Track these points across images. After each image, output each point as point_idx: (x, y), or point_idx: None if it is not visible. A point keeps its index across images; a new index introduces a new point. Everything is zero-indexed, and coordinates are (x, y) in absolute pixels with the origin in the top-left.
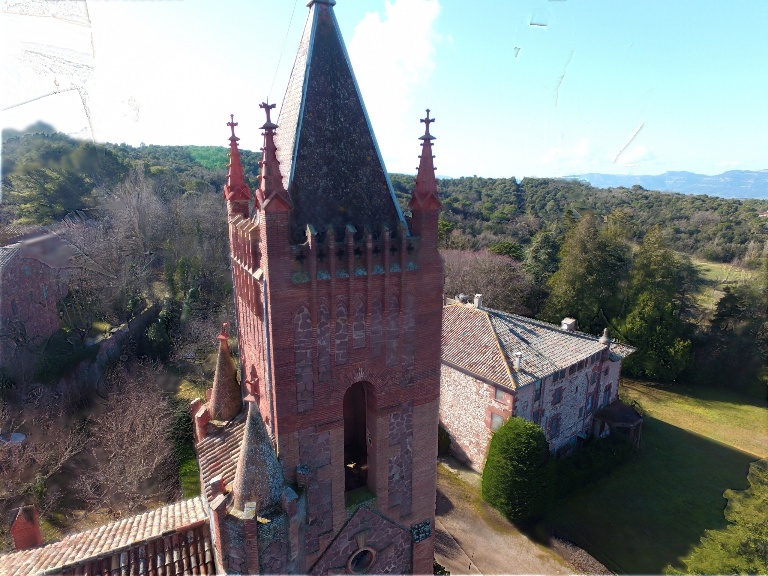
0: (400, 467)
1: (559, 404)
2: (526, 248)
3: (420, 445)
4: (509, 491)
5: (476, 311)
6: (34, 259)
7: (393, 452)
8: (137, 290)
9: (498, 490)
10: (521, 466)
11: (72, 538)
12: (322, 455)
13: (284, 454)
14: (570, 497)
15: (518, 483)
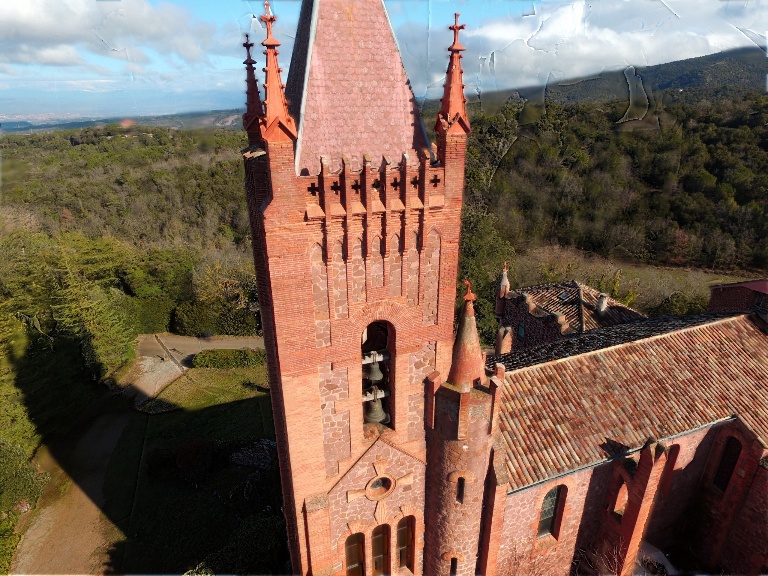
0: None
1: None
2: None
3: None
4: None
5: None
6: None
7: None
8: None
9: None
10: None
11: (589, 442)
12: None
13: None
14: None
15: None
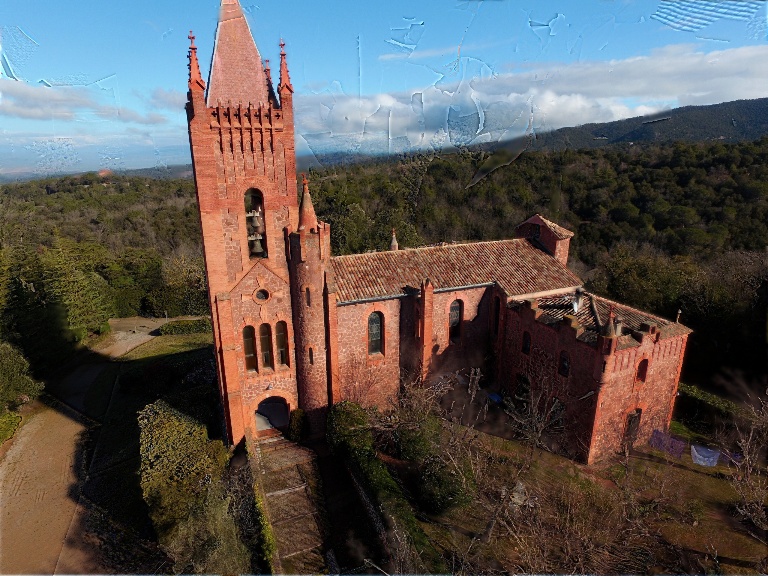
0: None
1: None
2: None
3: None
4: None
5: None
6: None
7: None
8: None
9: None
10: None
11: (395, 286)
12: None
13: None
14: None
15: None
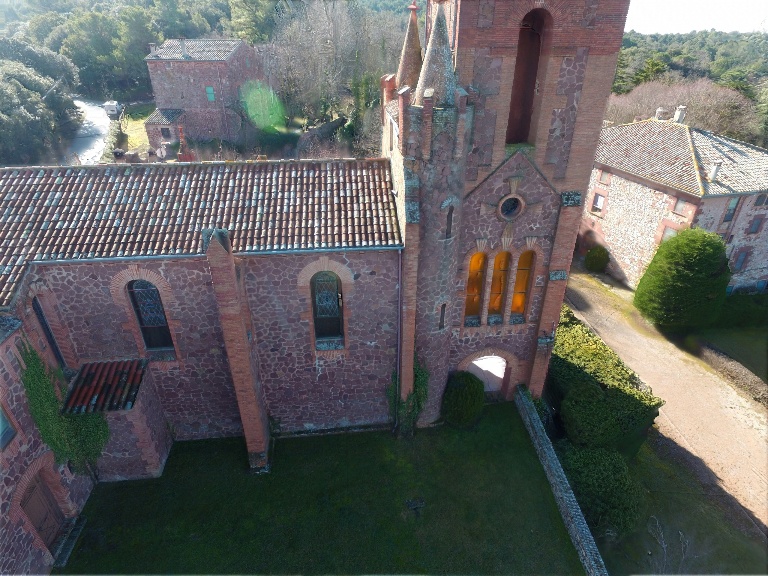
0: (562, 123)
1: (755, 235)
2: (765, 78)
3: (587, 104)
4: (666, 296)
5: (674, 125)
6: (252, 55)
7: (559, 102)
8: (329, 95)
9: (653, 295)
10: (687, 272)
11: None
12: (492, 83)
13: (460, 69)
14: (738, 330)
15: (679, 289)
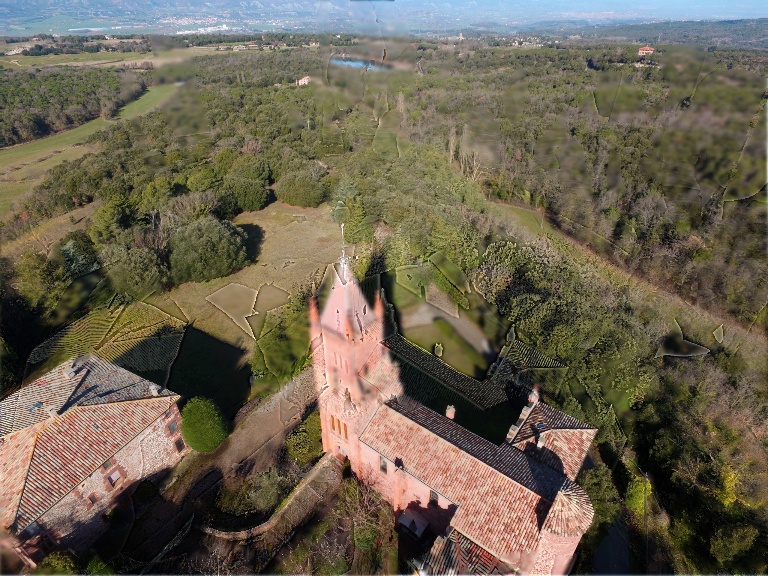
0: None
1: None
2: None
3: None
4: None
5: None
6: None
7: None
8: None
9: None
10: (217, 413)
11: None
12: None
13: None
14: None
15: (221, 420)
